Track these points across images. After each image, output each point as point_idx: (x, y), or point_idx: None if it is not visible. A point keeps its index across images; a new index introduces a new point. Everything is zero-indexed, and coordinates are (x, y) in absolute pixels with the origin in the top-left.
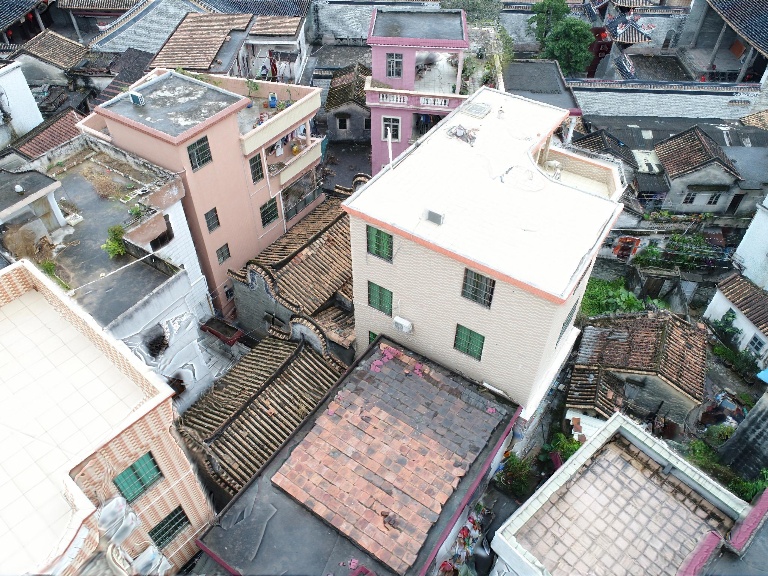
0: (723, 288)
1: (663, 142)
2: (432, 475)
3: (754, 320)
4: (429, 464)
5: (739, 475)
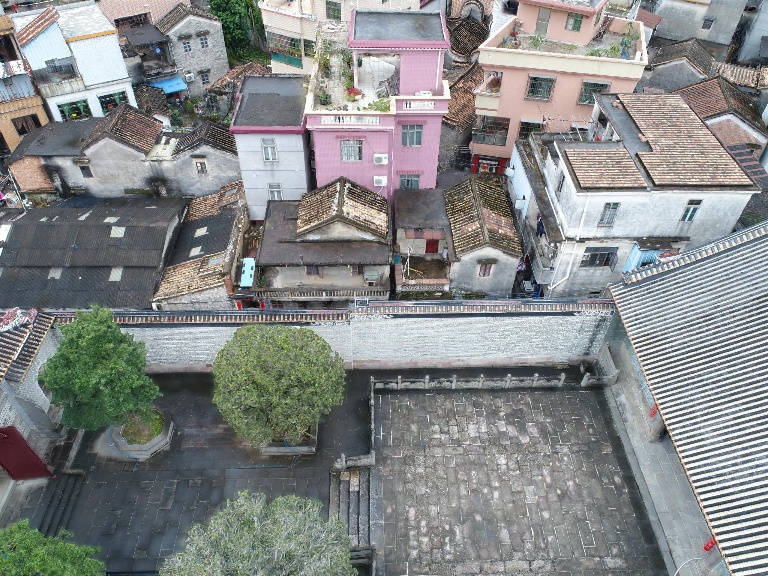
0: (168, 114)
1: (139, 147)
2: None
3: (165, 101)
4: None
5: (233, 60)
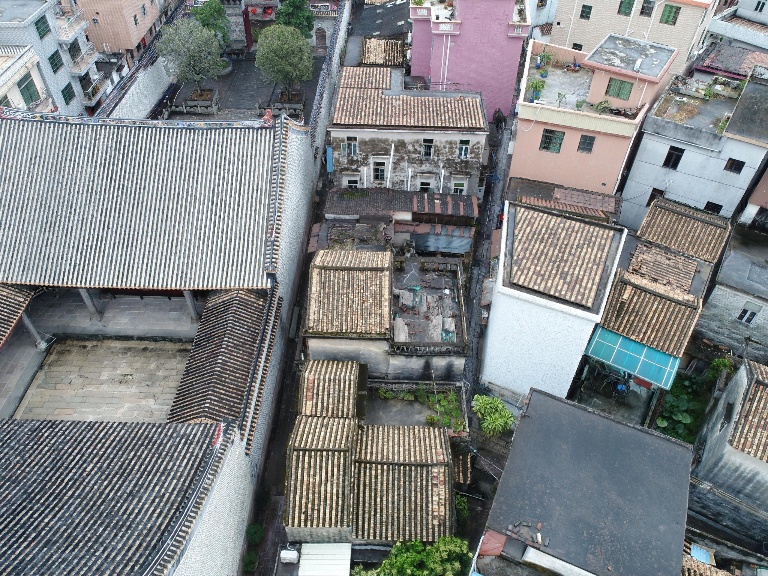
0: (545, 33)
1: None
2: (763, 57)
3: None
4: (759, 57)
5: None
